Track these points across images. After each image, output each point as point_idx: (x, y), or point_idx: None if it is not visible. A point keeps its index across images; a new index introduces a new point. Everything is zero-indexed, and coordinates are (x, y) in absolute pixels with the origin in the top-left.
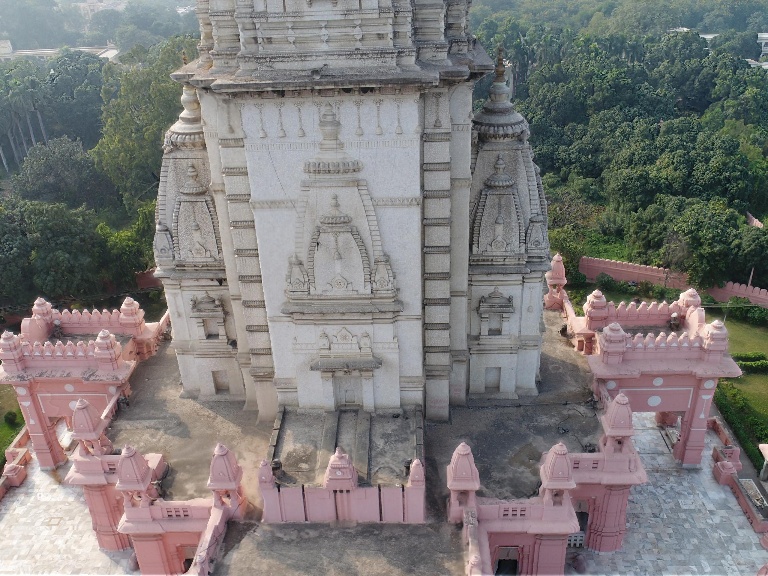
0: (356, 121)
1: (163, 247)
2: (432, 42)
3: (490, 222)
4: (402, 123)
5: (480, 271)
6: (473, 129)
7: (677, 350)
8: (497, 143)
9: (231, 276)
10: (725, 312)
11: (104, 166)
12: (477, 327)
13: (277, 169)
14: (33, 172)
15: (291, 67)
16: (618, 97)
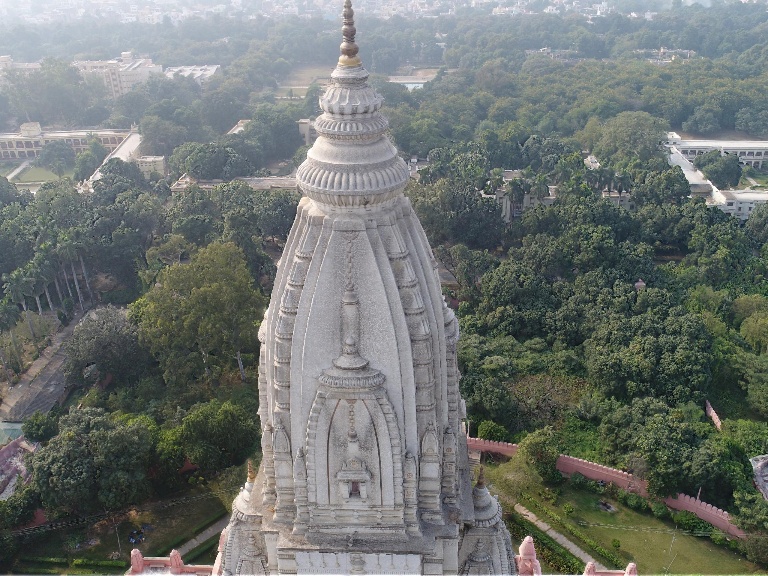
0: (376, 561)
1: None
2: (431, 509)
3: None
4: (409, 563)
5: None
6: None
7: None
8: (478, 530)
9: None
10: (676, 523)
11: (145, 338)
12: None
13: None
14: (85, 350)
15: (332, 531)
16: (602, 258)
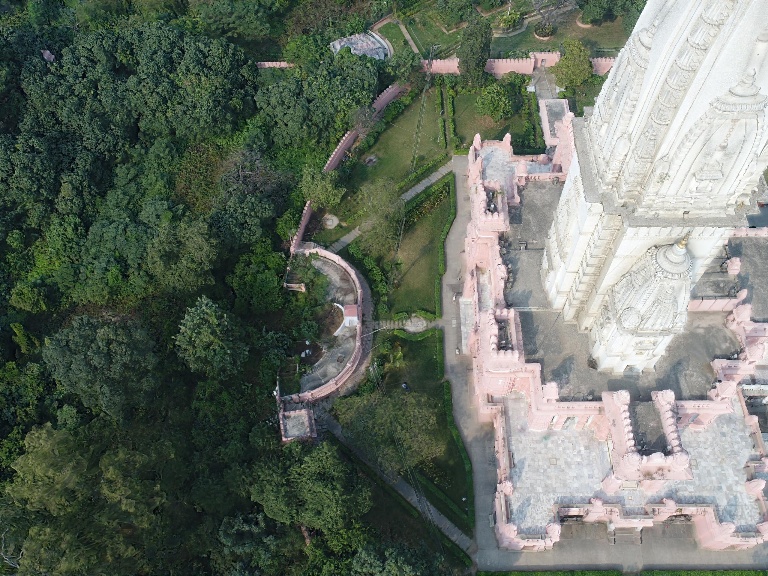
0: None
1: None
2: None
3: None
4: None
5: None
6: None
7: None
8: None
9: None
10: None
11: None
12: None
13: None
14: None
15: None
16: (6, 63)
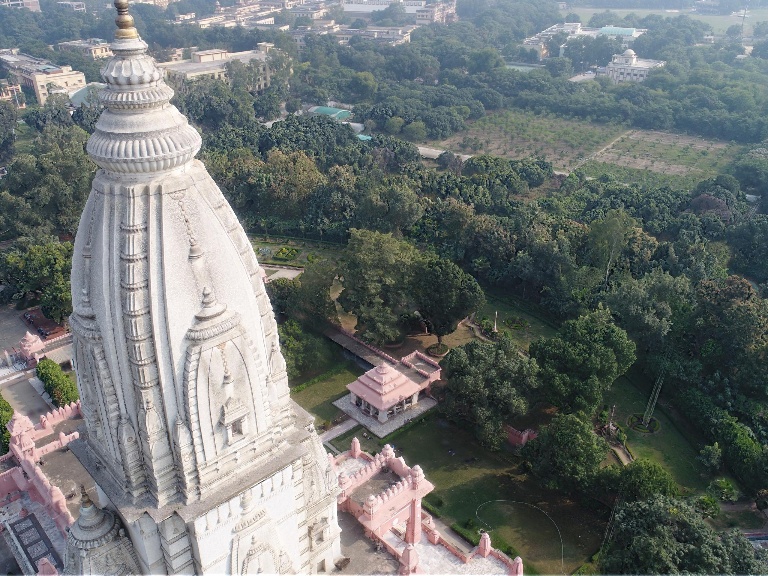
0: None
1: None
2: None
3: None
4: None
5: None
6: (108, 509)
7: None
8: None
9: None
10: None
11: None
12: None
13: None
14: None
15: None
16: None
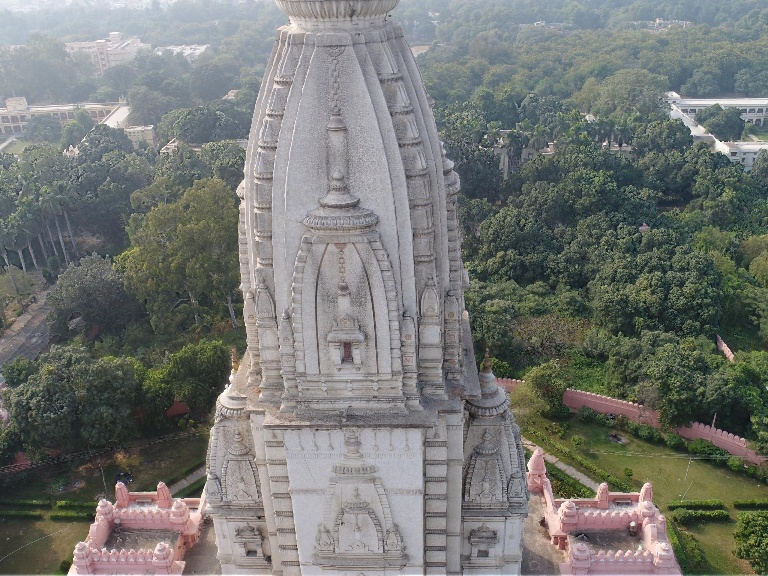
0: (373, 441)
1: (213, 491)
2: (432, 382)
3: (479, 480)
4: (409, 443)
5: (471, 514)
6: (465, 408)
7: (633, 564)
8: (484, 419)
9: (269, 520)
10: (691, 452)
11: (132, 285)
12: (468, 550)
13: (311, 469)
14: (68, 296)
15: (324, 407)
16: (604, 202)
